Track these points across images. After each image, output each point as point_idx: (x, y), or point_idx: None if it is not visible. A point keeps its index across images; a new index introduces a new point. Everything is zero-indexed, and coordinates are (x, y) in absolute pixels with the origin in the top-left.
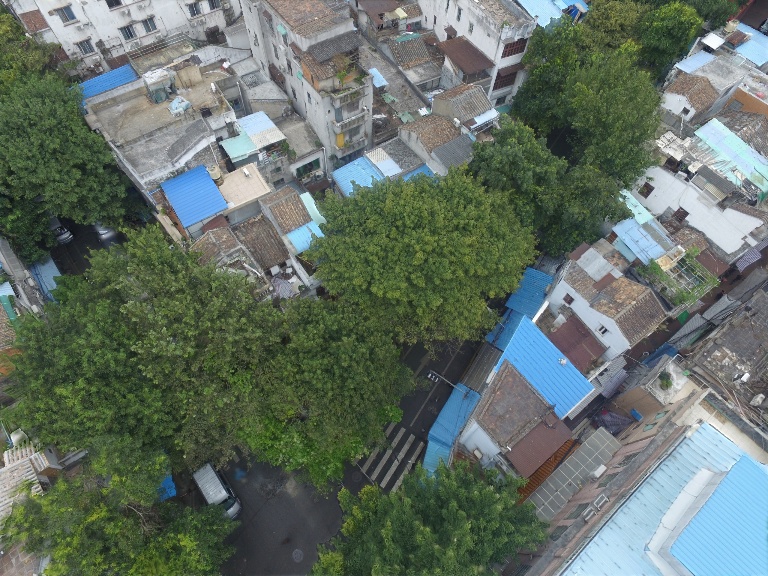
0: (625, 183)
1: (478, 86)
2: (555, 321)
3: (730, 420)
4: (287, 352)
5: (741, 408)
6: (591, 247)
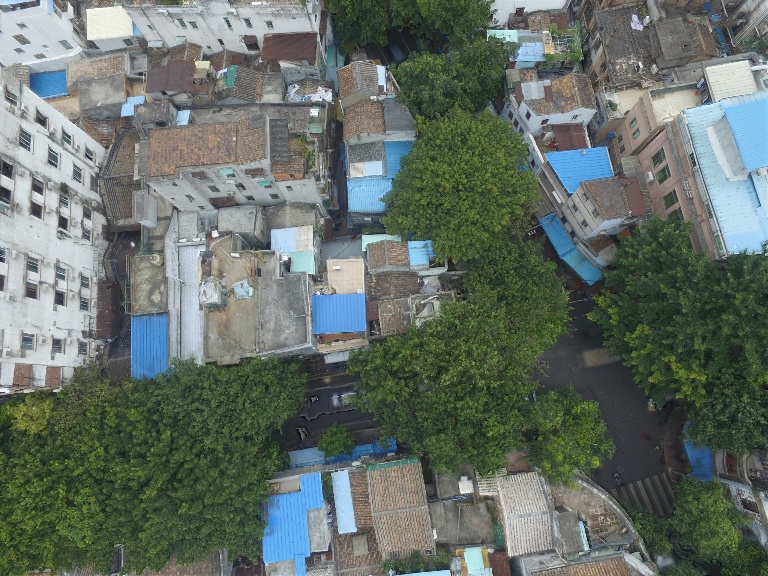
0: (484, 27)
1: (355, 63)
2: (544, 139)
3: (665, 93)
4: (511, 301)
5: (652, 81)
6: (521, 84)
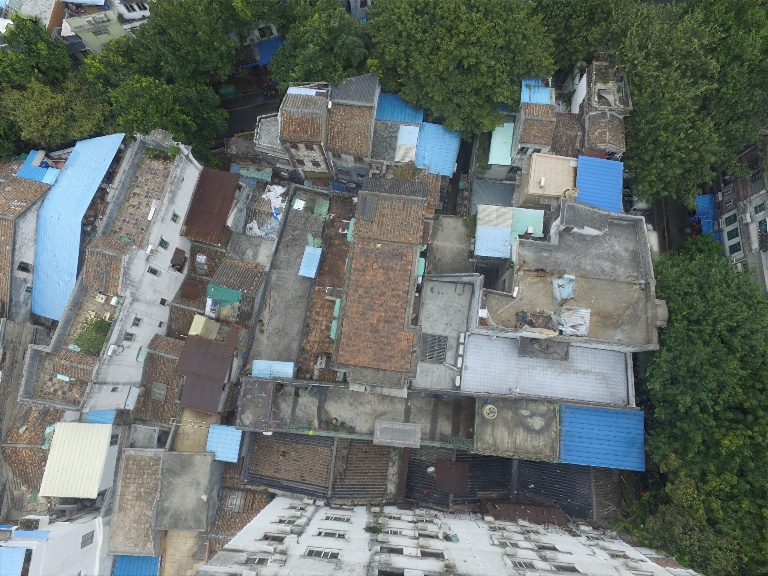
0: None
1: (282, 110)
2: None
3: None
4: None
5: None
6: None
